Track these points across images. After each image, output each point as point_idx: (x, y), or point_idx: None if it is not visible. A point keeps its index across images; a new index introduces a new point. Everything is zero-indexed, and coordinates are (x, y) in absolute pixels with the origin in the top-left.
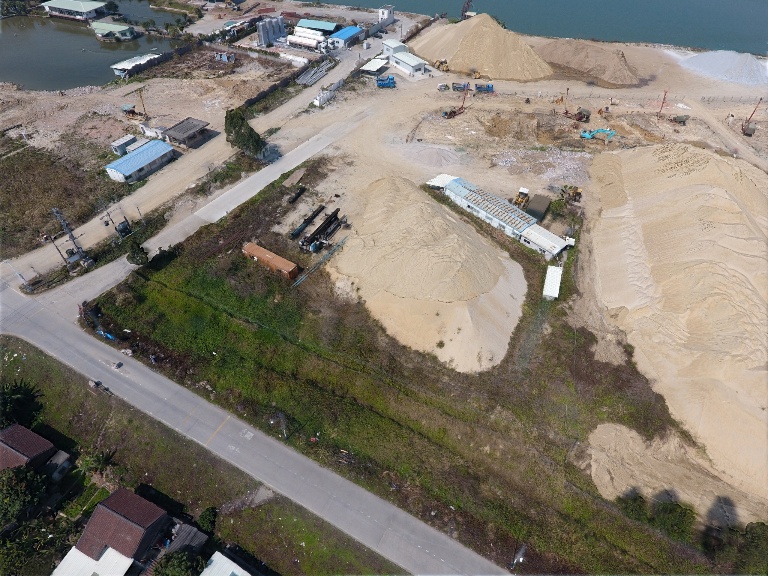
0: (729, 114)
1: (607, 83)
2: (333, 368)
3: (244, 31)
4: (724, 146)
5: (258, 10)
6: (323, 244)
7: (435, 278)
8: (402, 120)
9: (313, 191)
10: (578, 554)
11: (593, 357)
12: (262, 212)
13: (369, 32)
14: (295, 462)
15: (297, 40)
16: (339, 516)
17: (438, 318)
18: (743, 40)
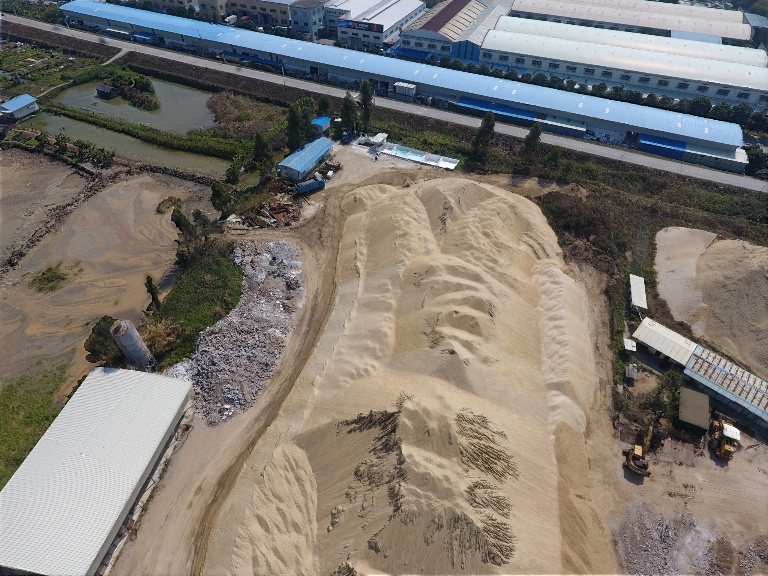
0: None
1: None
2: None
3: None
4: None
5: None
6: None
7: None
8: None
9: None
10: None
11: None
12: None
13: None
14: (746, 185)
15: None
16: (706, 171)
17: None
18: None
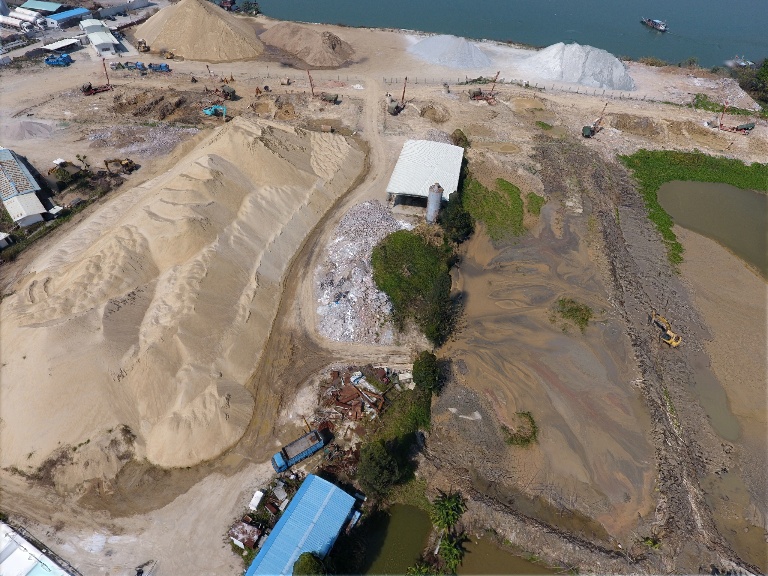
0: (385, 94)
1: (305, 65)
2: None
3: None
4: (355, 124)
5: None
6: None
7: None
8: (35, 96)
9: None
10: None
11: None
12: None
13: (101, 14)
14: None
15: (3, 20)
16: None
17: None
18: (500, 27)
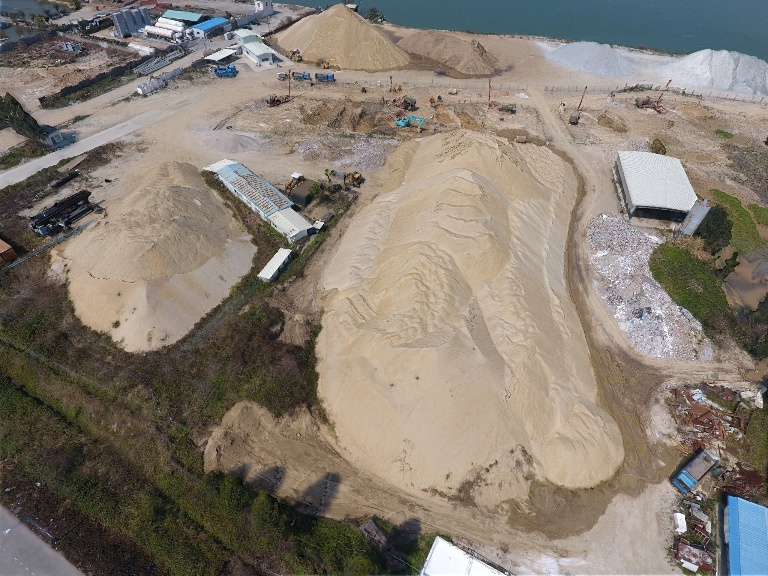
0: None
1: (458, 73)
2: None
3: (107, 22)
4: (542, 134)
5: (141, 2)
6: (64, 228)
7: (125, 258)
8: (223, 108)
9: (86, 176)
10: (135, 529)
11: (270, 337)
12: (18, 196)
13: (238, 23)
14: None
15: (154, 30)
16: None
17: (119, 298)
18: None
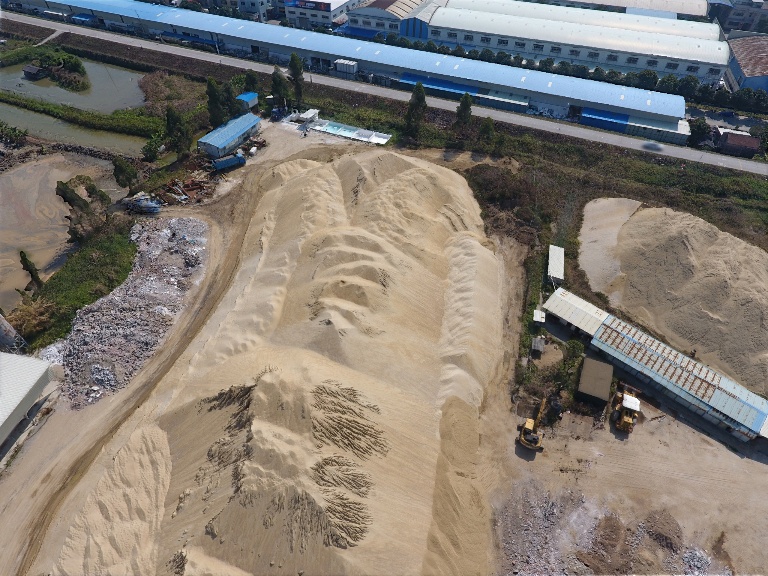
0: None
1: None
2: None
3: None
4: None
5: None
6: None
7: None
8: None
9: None
10: None
11: None
12: None
13: None
14: (685, 156)
15: None
16: (646, 143)
17: None
18: None
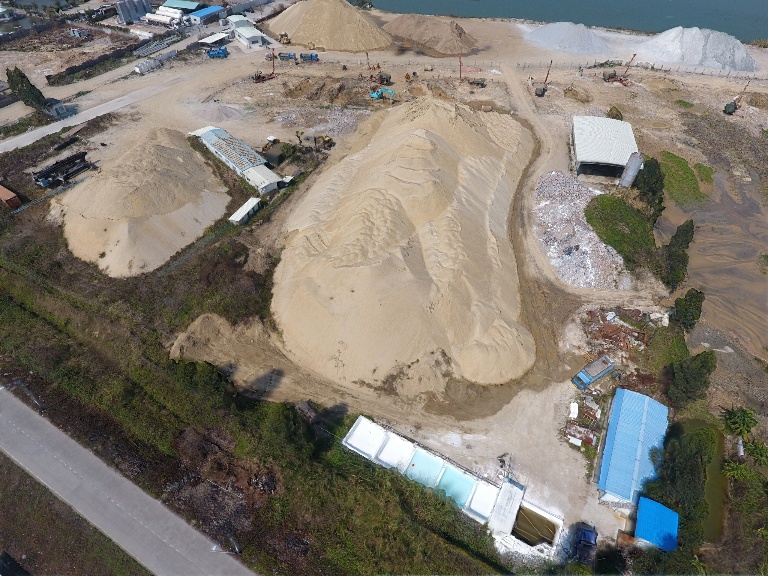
0: None
1: (437, 53)
2: (1, 273)
3: (112, 11)
4: (508, 105)
5: None
6: (63, 182)
7: (111, 200)
8: (212, 84)
9: (85, 141)
10: (108, 403)
11: (234, 266)
12: (25, 157)
13: (233, 11)
14: None
15: (154, 18)
16: None
17: (106, 233)
18: None
